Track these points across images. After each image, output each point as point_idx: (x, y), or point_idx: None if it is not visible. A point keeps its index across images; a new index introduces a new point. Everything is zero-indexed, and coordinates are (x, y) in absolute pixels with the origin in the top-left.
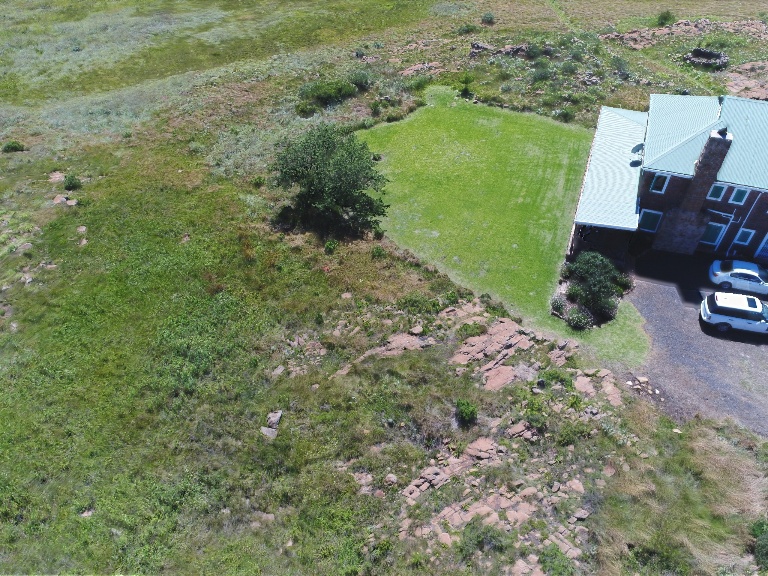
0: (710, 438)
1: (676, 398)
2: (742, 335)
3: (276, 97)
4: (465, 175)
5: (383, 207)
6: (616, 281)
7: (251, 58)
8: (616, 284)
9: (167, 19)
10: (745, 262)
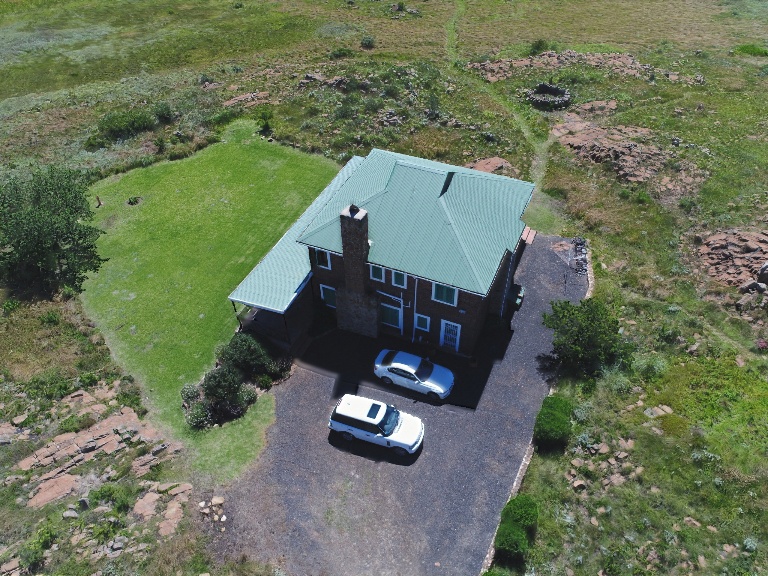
0: None
1: (239, 529)
2: (366, 447)
3: (86, 126)
4: (207, 226)
5: (101, 261)
6: (265, 369)
7: (107, 80)
8: (265, 373)
9: (47, 35)
10: (409, 355)
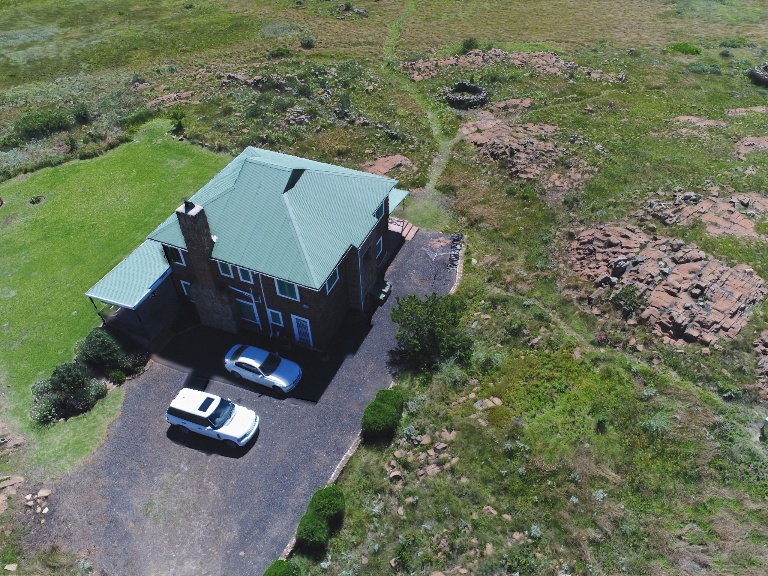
0: None
1: (58, 520)
2: (201, 440)
3: (8, 126)
4: (100, 224)
5: None
6: (118, 365)
7: (44, 80)
8: (118, 368)
9: None
10: (258, 349)
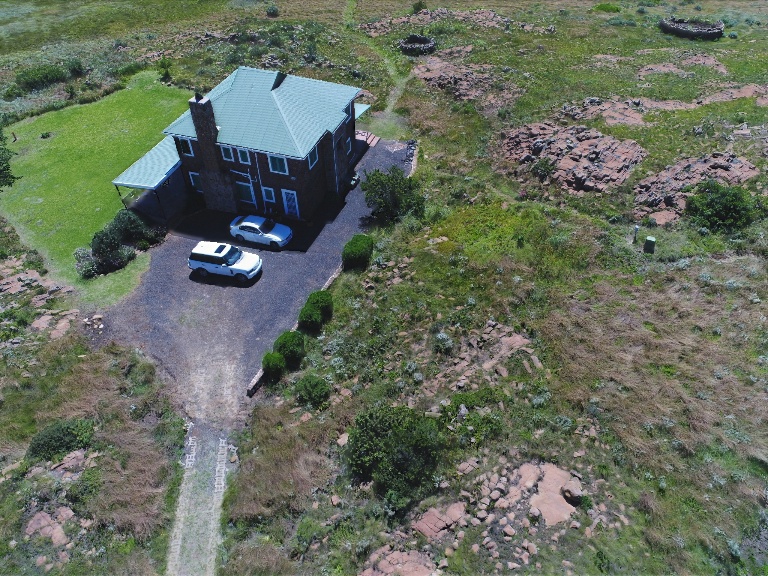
0: (99, 361)
1: (113, 331)
2: (217, 279)
3: None
4: (108, 149)
5: (15, 179)
6: (143, 236)
7: (29, 50)
8: (143, 238)
9: None
10: (256, 217)
